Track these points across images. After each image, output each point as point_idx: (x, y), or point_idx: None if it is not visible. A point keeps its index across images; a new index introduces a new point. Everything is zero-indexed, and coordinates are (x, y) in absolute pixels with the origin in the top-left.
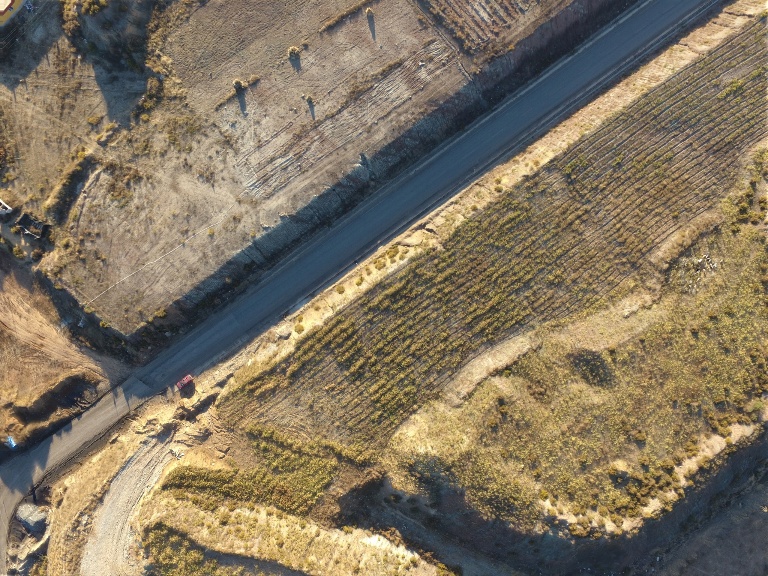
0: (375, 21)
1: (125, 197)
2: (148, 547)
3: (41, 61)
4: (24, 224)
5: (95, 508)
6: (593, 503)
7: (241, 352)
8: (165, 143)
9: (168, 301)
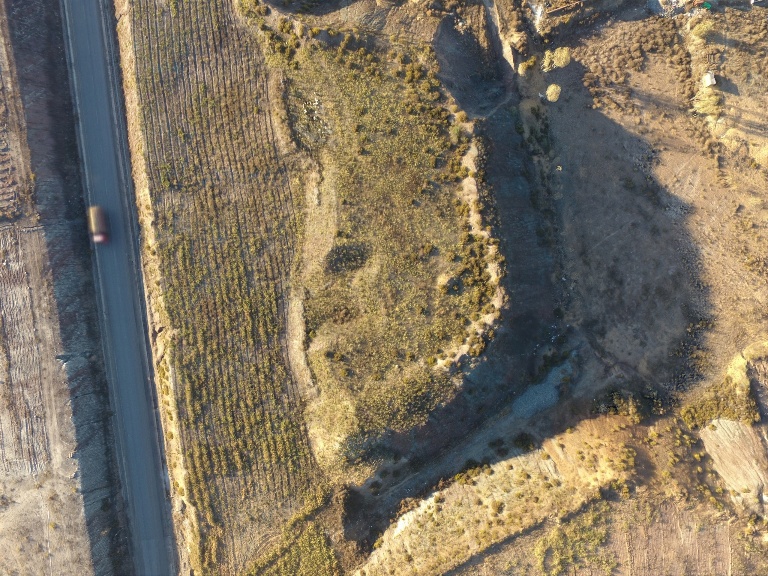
0: None
1: None
2: None
3: None
4: None
5: None
6: (463, 322)
7: (179, 551)
8: None
9: None
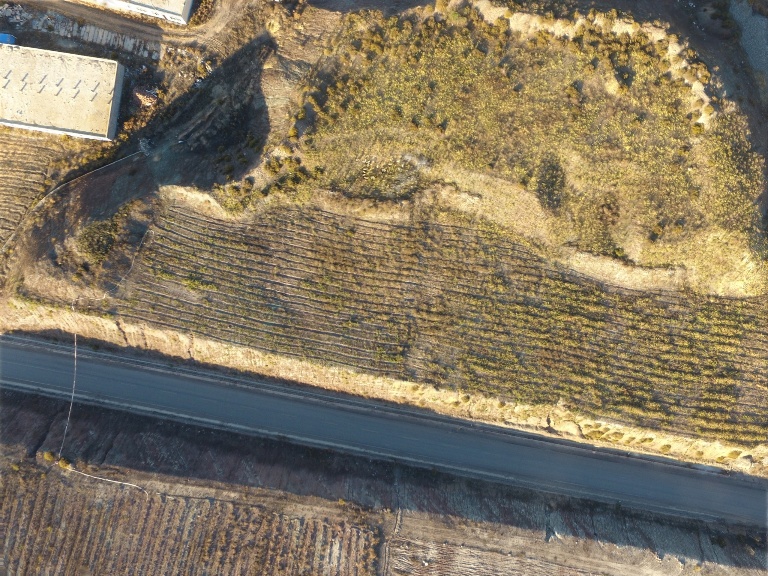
0: None
1: None
2: None
3: None
4: None
5: None
6: (666, 81)
7: None
8: None
9: None
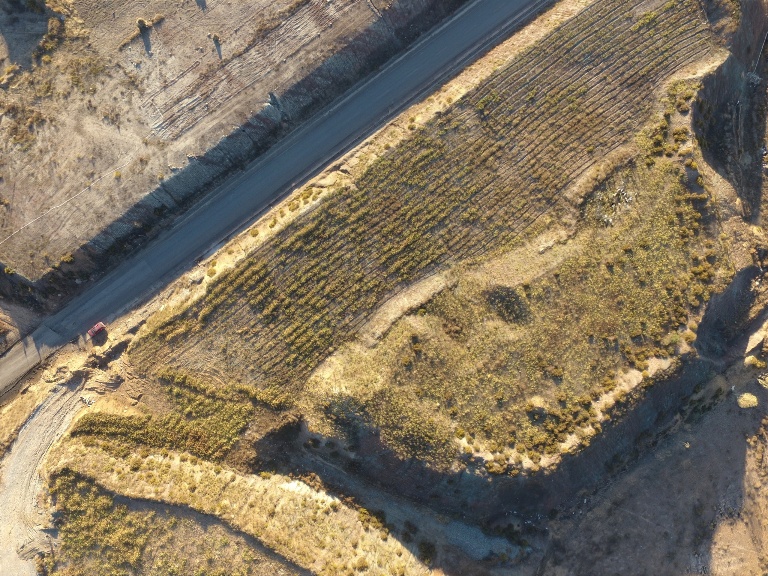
0: None
1: (28, 140)
2: (55, 494)
3: None
4: None
5: (3, 457)
6: (510, 440)
7: (154, 299)
8: (68, 85)
9: (75, 246)
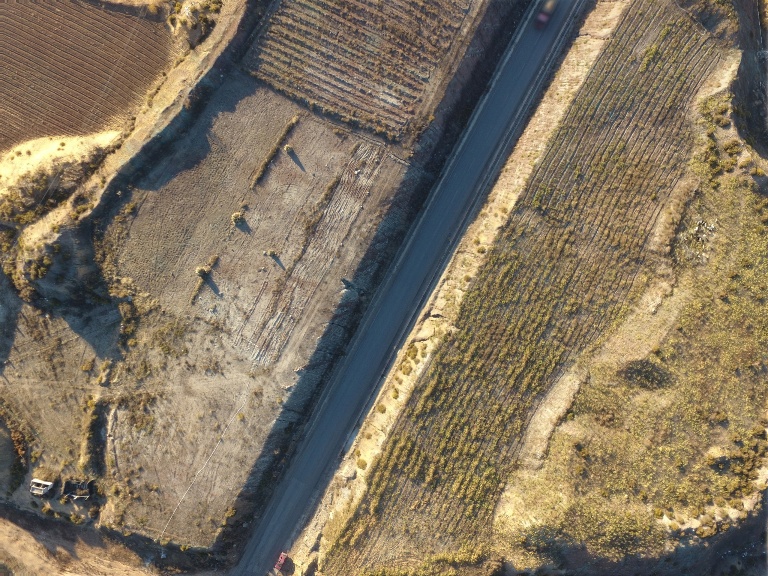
0: (297, 154)
1: (148, 423)
2: None
3: (15, 336)
4: (69, 491)
5: None
6: (707, 499)
7: (319, 509)
8: (161, 357)
9: (232, 498)
